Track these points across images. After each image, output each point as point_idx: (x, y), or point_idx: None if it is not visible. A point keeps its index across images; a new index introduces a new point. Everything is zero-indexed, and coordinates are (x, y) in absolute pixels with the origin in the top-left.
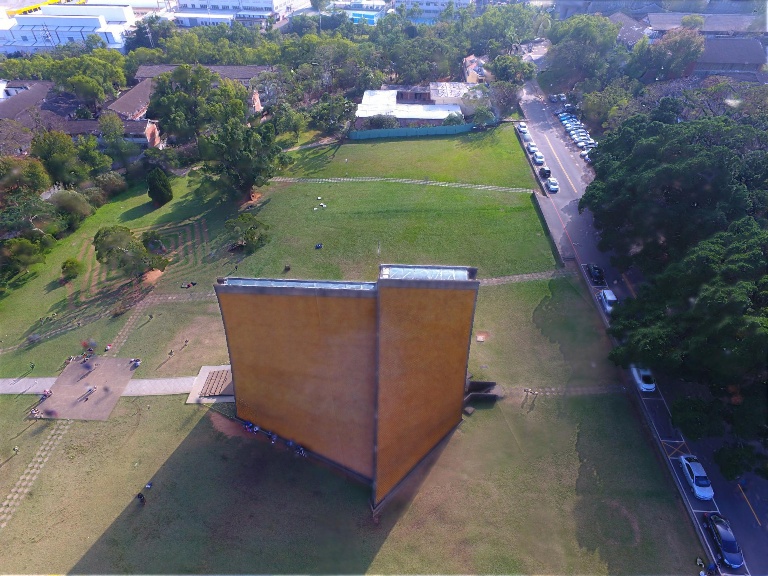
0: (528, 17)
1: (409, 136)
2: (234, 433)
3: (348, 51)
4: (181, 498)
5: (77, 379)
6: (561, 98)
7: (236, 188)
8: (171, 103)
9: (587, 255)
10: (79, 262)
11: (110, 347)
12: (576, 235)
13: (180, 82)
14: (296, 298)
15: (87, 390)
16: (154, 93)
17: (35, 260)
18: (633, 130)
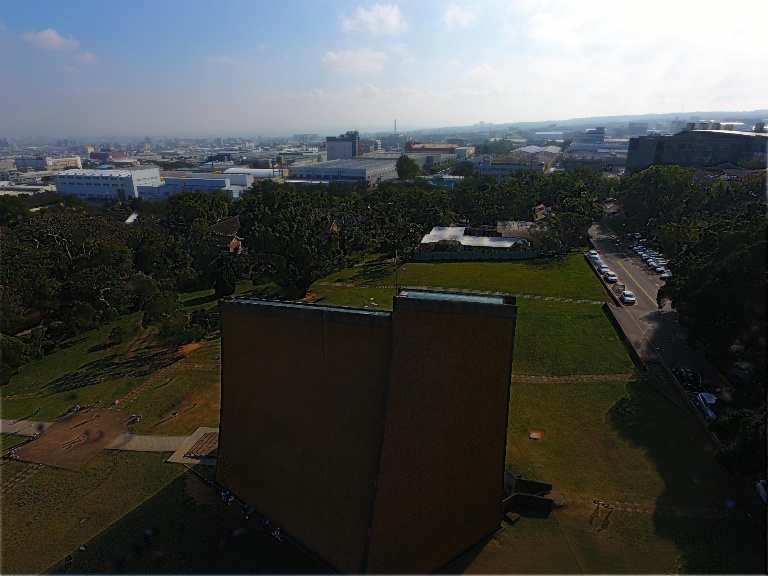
0: (597, 176)
1: (472, 259)
2: (205, 500)
3: (422, 197)
4: (112, 569)
5: (71, 426)
6: (635, 236)
7: (292, 283)
8: (255, 218)
9: (676, 360)
10: (127, 330)
11: (118, 402)
12: (660, 341)
13: (268, 206)
14: (302, 323)
15: (75, 438)
16: (243, 211)
17: (91, 325)
18: (717, 233)
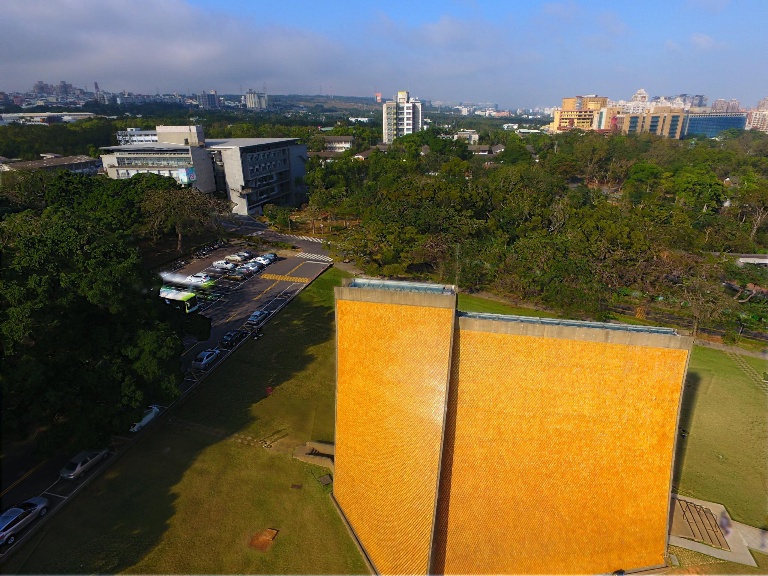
0: None
1: None
2: None
3: None
4: None
5: None
6: None
7: None
8: None
9: None
10: None
11: None
12: None
13: None
14: None
15: None
16: None
17: None
18: None
